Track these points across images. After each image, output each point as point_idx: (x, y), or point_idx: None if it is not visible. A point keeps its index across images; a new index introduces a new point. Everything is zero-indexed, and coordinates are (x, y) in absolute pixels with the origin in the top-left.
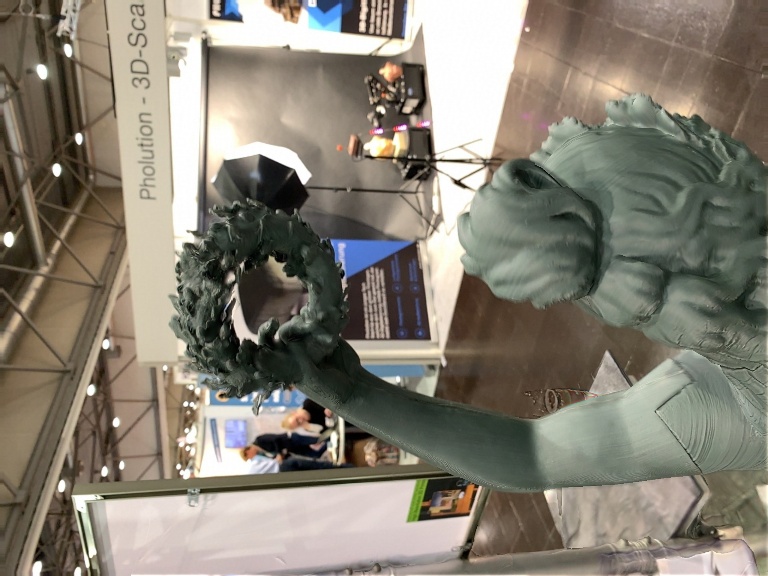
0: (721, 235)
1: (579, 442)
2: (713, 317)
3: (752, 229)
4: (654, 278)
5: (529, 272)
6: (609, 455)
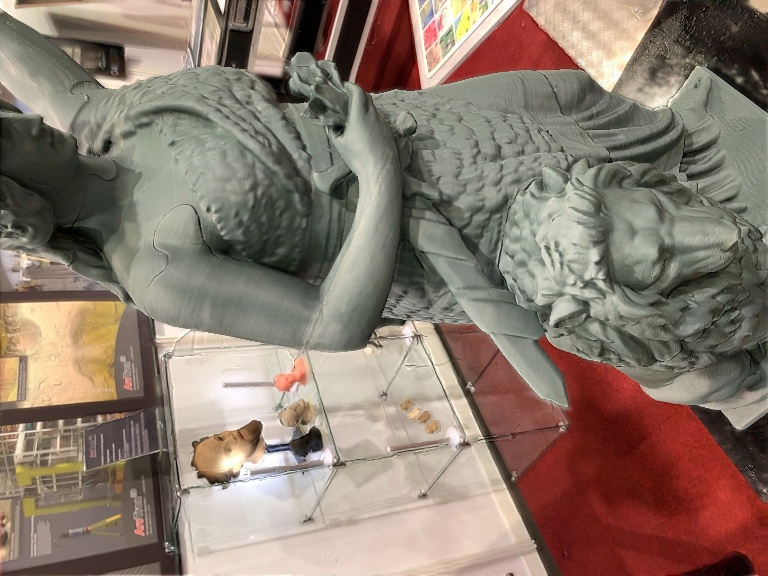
0: None
1: None
2: None
3: None
4: None
5: None
6: None
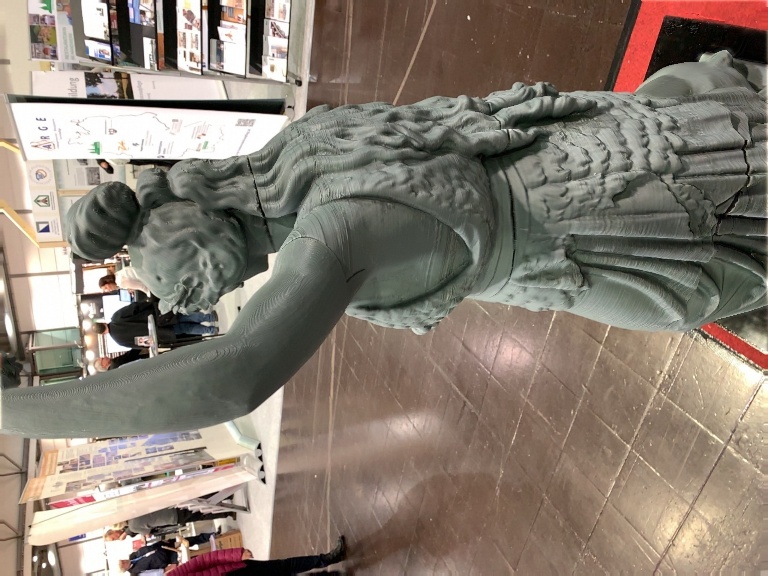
0: None
1: None
2: None
3: None
4: None
5: None
6: (263, 287)
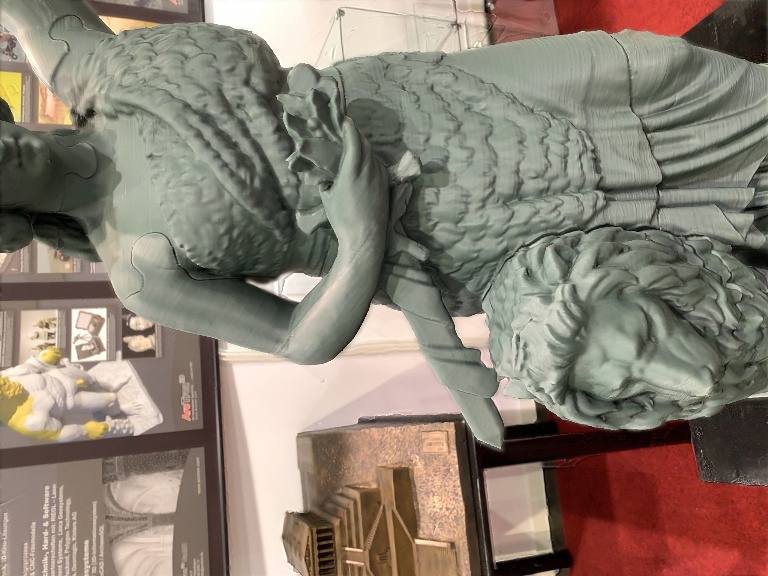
0: None
1: None
2: None
3: None
4: None
5: None
6: None
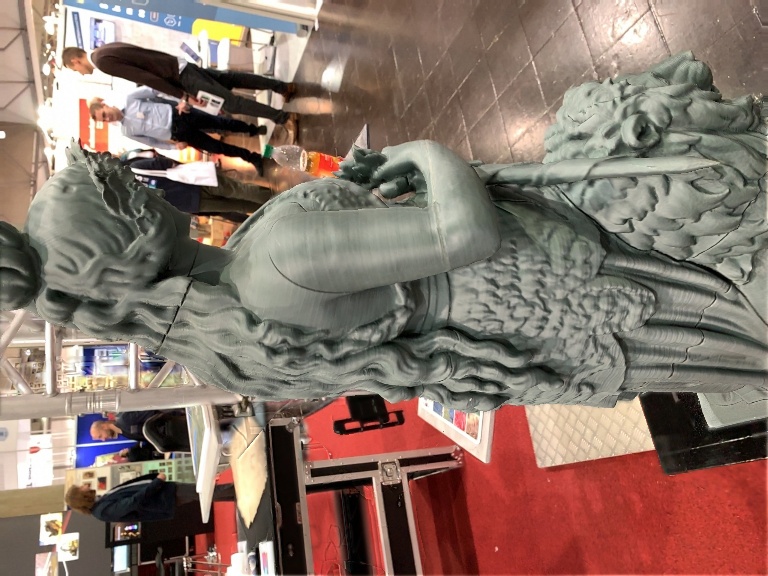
0: (116, 287)
1: None
2: (99, 332)
3: (139, 284)
4: (59, 312)
5: None
6: None
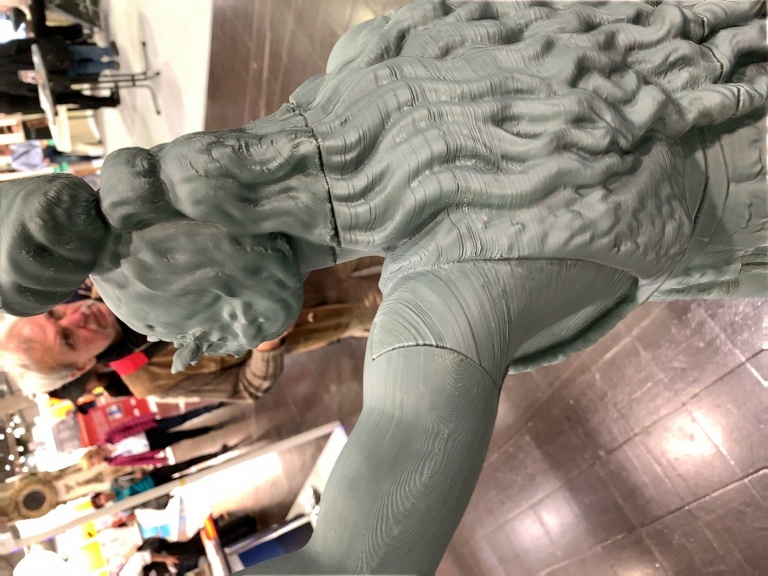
0: None
1: (340, 474)
2: None
3: None
4: (131, 148)
5: (6, 204)
6: (375, 446)
